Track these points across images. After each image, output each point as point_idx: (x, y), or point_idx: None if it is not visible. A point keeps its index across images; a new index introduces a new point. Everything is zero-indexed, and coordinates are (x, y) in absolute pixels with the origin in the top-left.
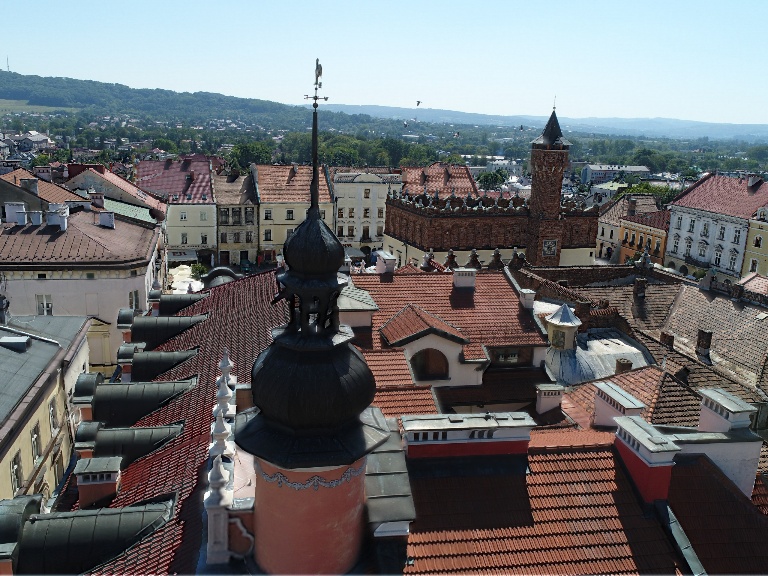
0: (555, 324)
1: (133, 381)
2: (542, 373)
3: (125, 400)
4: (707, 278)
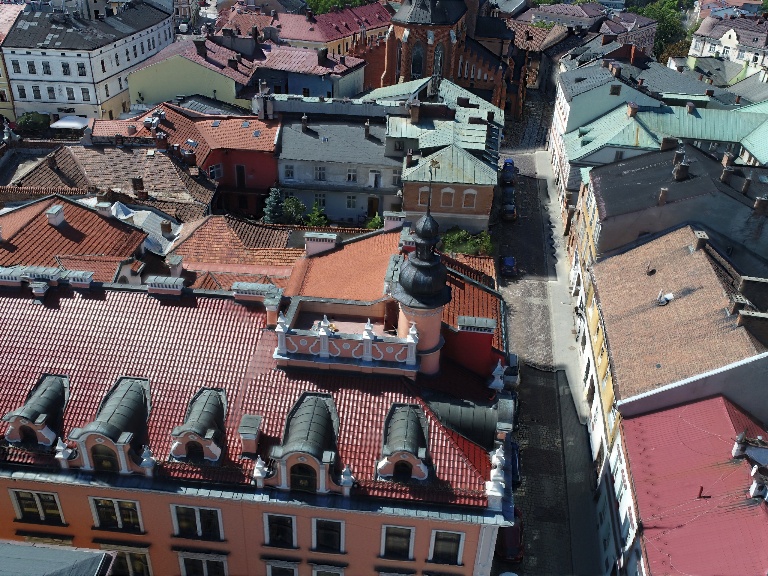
0: (123, 219)
1: (52, 429)
2: (150, 255)
3: (130, 420)
4: (87, 136)
